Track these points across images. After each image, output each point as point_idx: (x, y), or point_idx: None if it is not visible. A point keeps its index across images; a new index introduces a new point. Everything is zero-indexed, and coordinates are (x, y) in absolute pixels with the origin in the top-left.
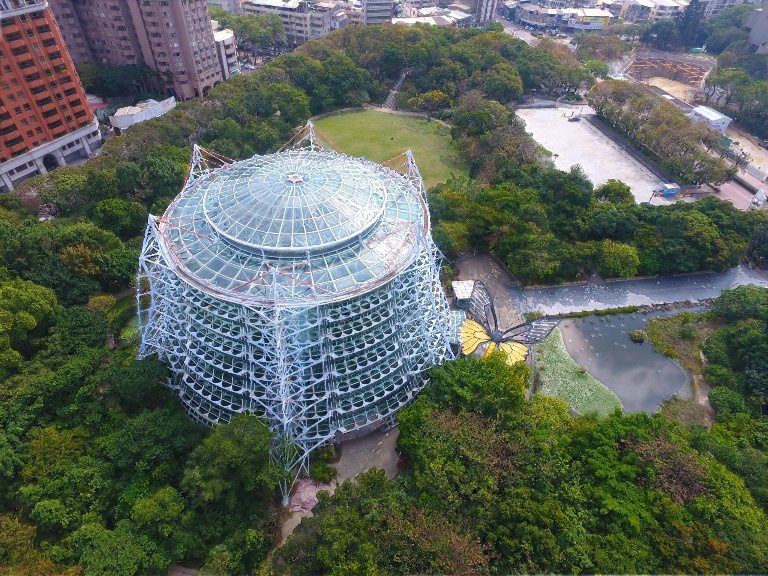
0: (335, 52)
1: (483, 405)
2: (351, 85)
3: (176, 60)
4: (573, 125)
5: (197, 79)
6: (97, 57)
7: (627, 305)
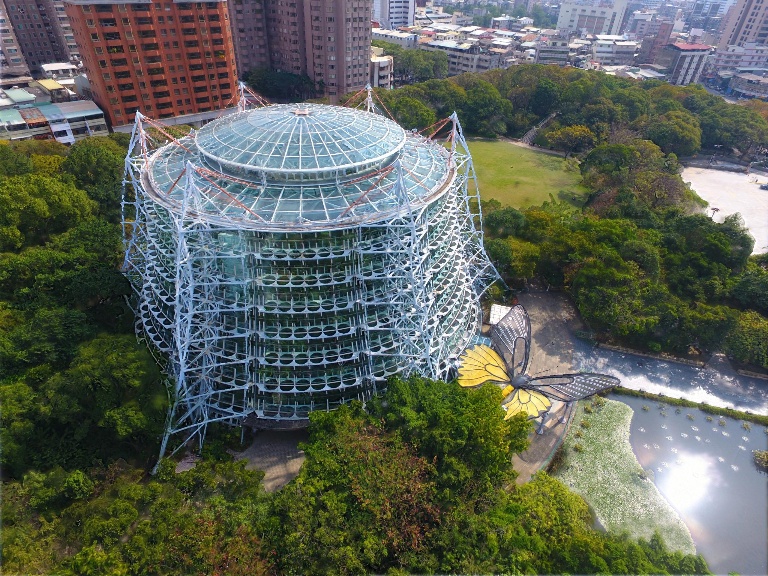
0: (482, 81)
1: (426, 440)
2: (489, 114)
3: (330, 72)
4: (765, 193)
5: (344, 91)
6: (274, 67)
7: (764, 414)
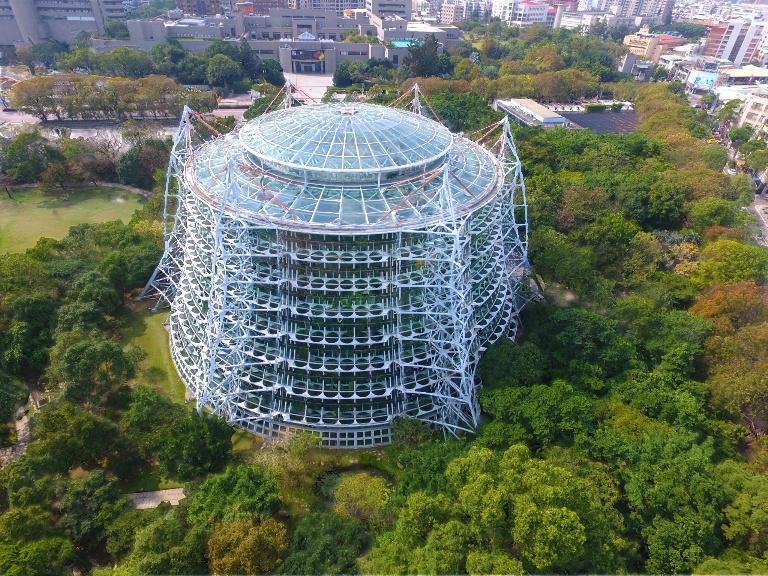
0: None
1: None
2: None
3: None
4: None
5: None
6: None
7: None
